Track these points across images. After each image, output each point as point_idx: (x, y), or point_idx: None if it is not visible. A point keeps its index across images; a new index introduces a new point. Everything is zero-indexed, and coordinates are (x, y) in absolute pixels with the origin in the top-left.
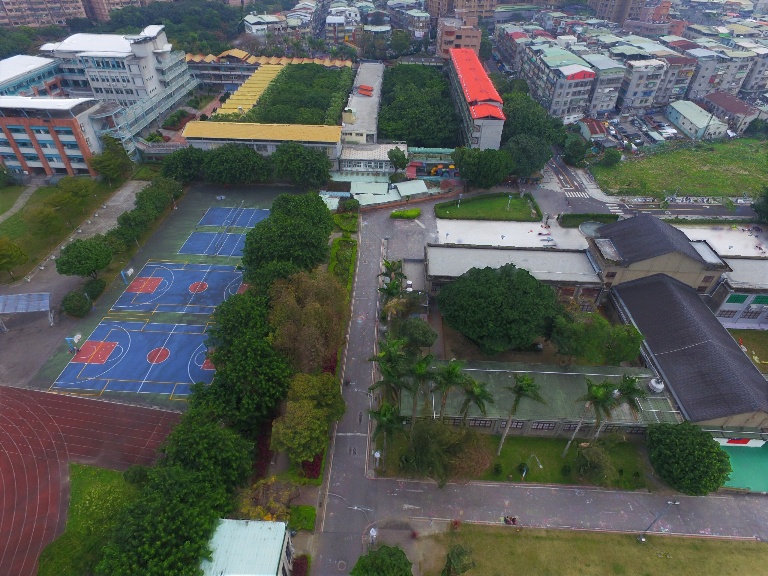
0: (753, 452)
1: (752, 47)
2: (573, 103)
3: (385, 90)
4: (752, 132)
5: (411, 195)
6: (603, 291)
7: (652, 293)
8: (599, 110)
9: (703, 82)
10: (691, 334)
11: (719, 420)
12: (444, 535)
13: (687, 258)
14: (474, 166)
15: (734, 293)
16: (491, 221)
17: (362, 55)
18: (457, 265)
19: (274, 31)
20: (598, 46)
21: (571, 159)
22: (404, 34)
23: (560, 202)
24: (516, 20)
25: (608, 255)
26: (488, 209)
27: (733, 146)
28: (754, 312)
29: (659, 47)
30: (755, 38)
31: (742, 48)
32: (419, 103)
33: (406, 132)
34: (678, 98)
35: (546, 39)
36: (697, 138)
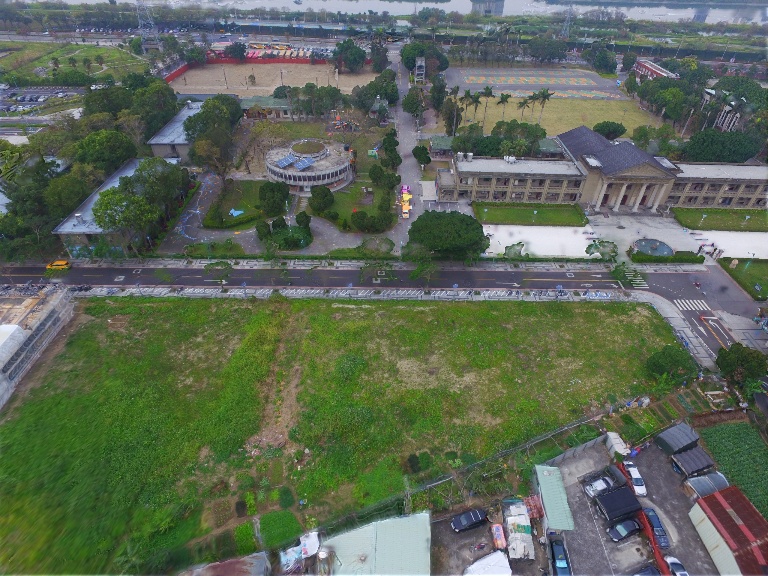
0: None
1: None
2: None
3: None
4: None
5: None
6: None
7: None
8: None
9: None
10: None
11: None
12: (684, 138)
13: None
14: None
15: None
16: None
17: None
18: (764, 172)
19: None
20: None
21: None
22: None
23: (710, 290)
24: None
25: (664, 162)
26: None
27: (337, 491)
28: None
29: None
30: None
31: None
32: None
33: None
34: None
35: None
36: None
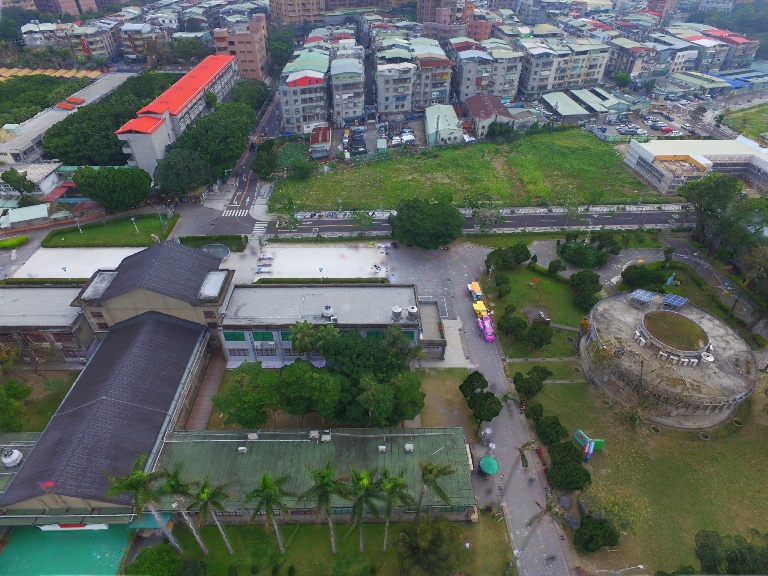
0: (89, 537)
1: (531, 47)
2: (307, 111)
3: (103, 102)
4: (492, 136)
5: (24, 221)
6: (76, 335)
7: (125, 335)
8: (345, 117)
9: (470, 85)
10: (100, 389)
11: (32, 503)
12: None
13: (162, 294)
14: (92, 187)
15: (223, 331)
16: (102, 248)
17: (153, 64)
18: None
19: (34, 40)
20: (376, 49)
21: (256, 173)
22: (189, 41)
23: (206, 222)
24: (340, 24)
25: (93, 292)
26: (114, 234)
27: (463, 152)
28: (268, 349)
29: (429, 49)
30: (555, 38)
31: (525, 48)
32: (93, 117)
33: (71, 149)
34: (442, 102)
35: (317, 43)
36: (429, 144)
